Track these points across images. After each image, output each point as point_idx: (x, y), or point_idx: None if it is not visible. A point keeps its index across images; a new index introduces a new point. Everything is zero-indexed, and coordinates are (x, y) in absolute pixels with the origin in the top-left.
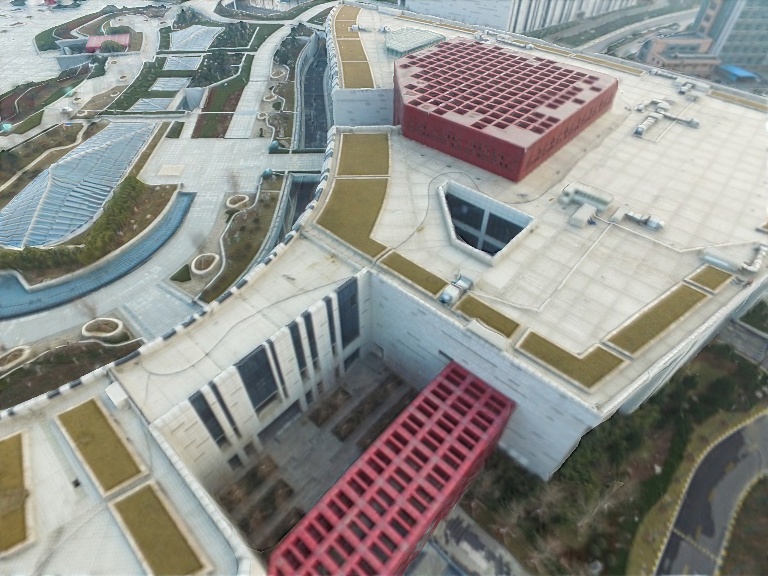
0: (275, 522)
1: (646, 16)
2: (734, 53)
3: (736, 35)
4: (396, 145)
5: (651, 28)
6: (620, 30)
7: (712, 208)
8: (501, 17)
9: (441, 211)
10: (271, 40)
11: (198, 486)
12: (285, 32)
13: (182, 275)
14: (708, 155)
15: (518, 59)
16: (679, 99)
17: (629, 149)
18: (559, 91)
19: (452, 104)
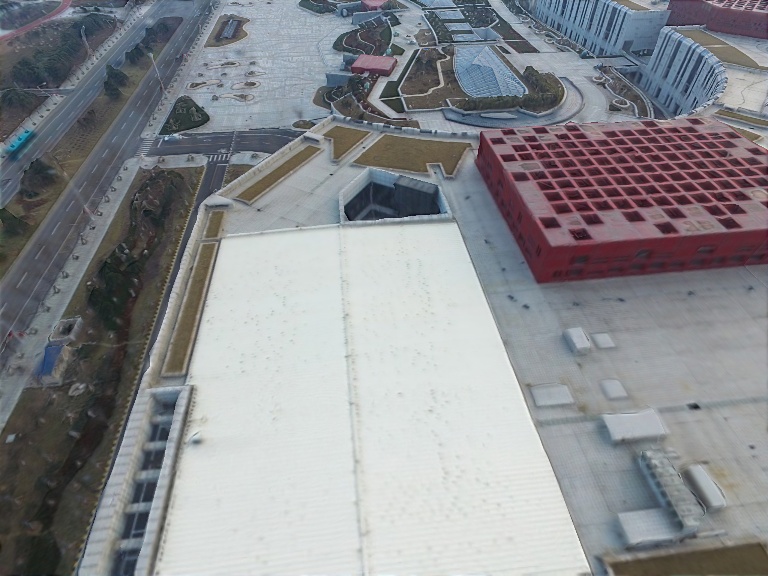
0: None
1: None
2: None
3: None
4: None
5: None
6: None
7: None
8: None
9: None
10: None
11: None
12: None
13: (615, 108)
14: None
15: None
16: None
17: None
18: None
19: (750, 6)
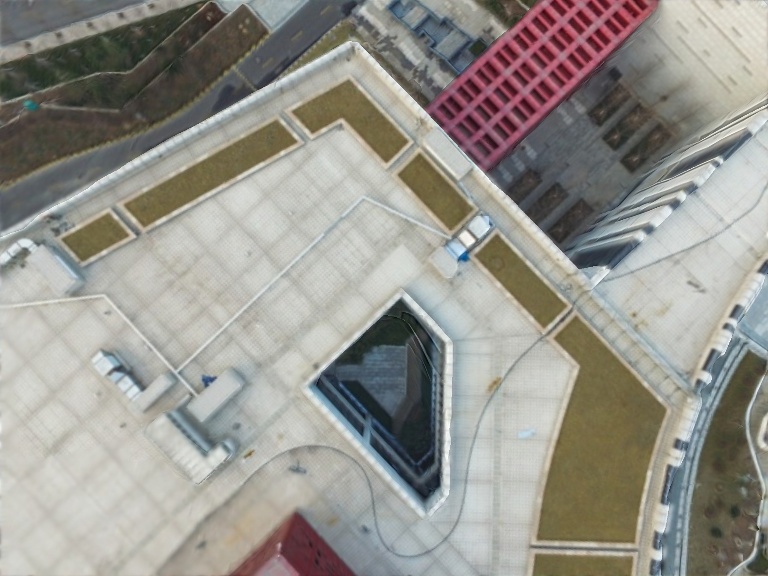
0: (616, 116)
1: None
2: None
3: None
4: None
5: None
6: None
7: None
8: None
9: (453, 431)
10: None
11: (759, 3)
12: None
13: None
14: None
15: None
16: None
17: None
18: None
19: None
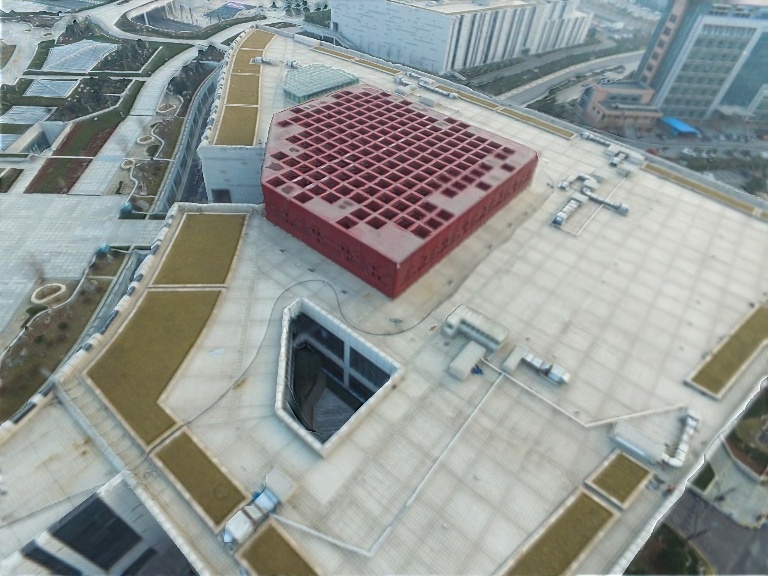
0: None
1: (592, 56)
2: (676, 106)
3: (678, 88)
4: (253, 233)
5: (596, 70)
6: (565, 70)
7: (633, 345)
8: (438, 51)
9: (278, 349)
10: (172, 63)
11: None
12: (192, 54)
13: None
14: (635, 257)
15: (426, 119)
16: (609, 174)
17: (543, 246)
18: (463, 169)
19: (323, 186)
